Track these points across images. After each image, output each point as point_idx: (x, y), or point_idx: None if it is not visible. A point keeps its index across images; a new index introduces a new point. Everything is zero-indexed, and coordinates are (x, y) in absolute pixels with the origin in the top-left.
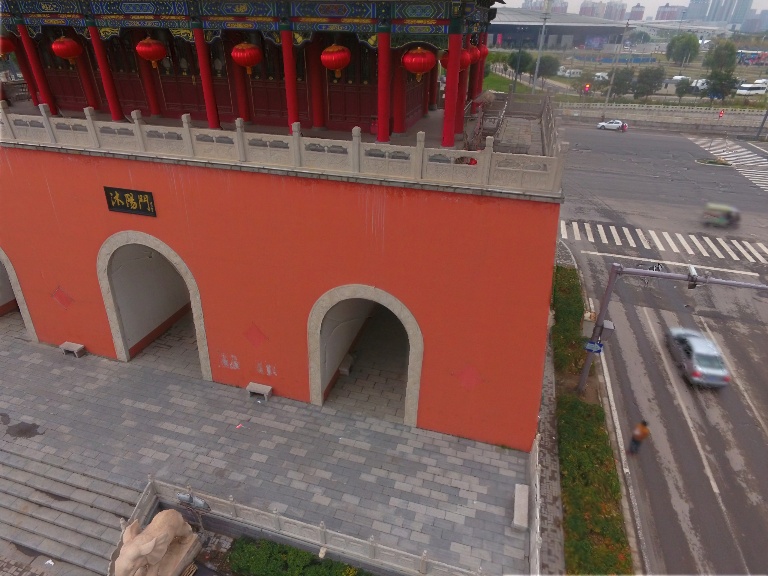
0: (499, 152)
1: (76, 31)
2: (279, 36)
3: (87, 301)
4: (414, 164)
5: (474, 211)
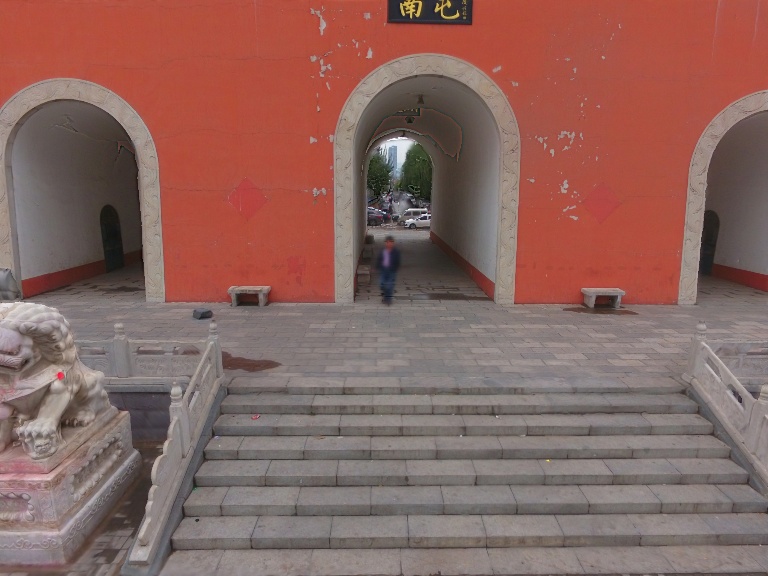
0: None
1: None
2: None
3: None
4: None
5: None
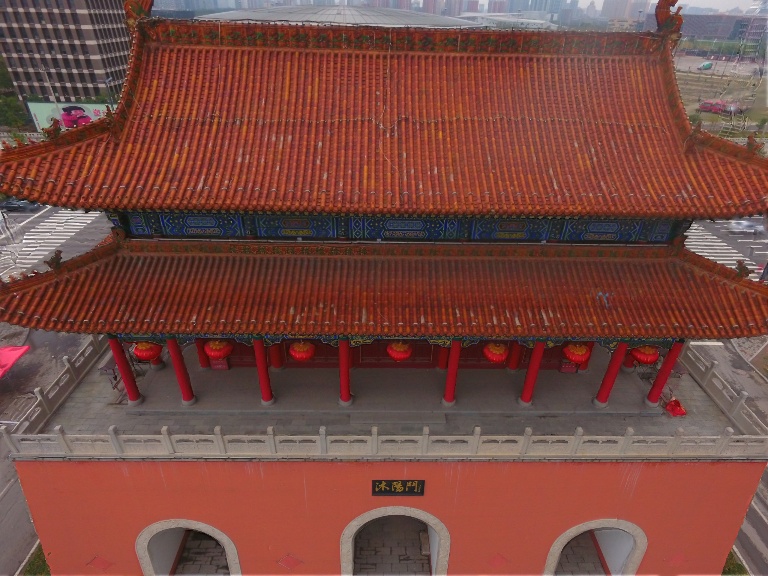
0: (733, 435)
1: (323, 341)
2: (533, 343)
3: (319, 560)
4: (670, 447)
5: (708, 469)
